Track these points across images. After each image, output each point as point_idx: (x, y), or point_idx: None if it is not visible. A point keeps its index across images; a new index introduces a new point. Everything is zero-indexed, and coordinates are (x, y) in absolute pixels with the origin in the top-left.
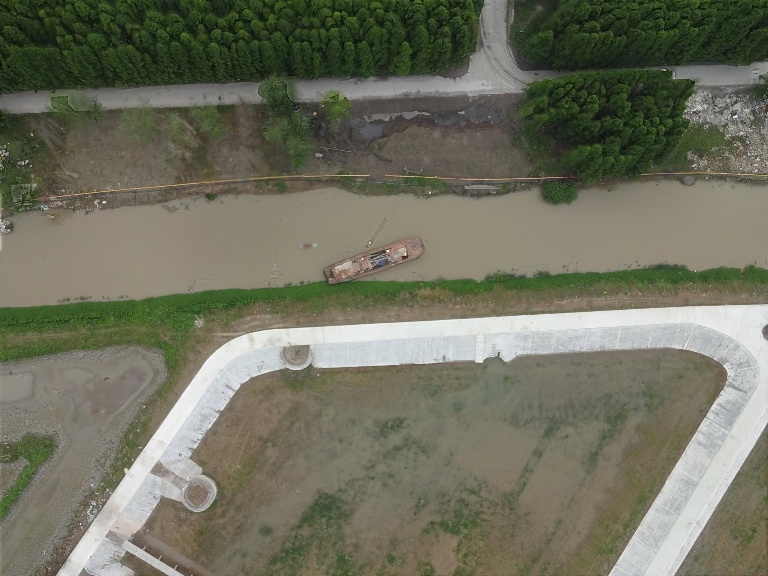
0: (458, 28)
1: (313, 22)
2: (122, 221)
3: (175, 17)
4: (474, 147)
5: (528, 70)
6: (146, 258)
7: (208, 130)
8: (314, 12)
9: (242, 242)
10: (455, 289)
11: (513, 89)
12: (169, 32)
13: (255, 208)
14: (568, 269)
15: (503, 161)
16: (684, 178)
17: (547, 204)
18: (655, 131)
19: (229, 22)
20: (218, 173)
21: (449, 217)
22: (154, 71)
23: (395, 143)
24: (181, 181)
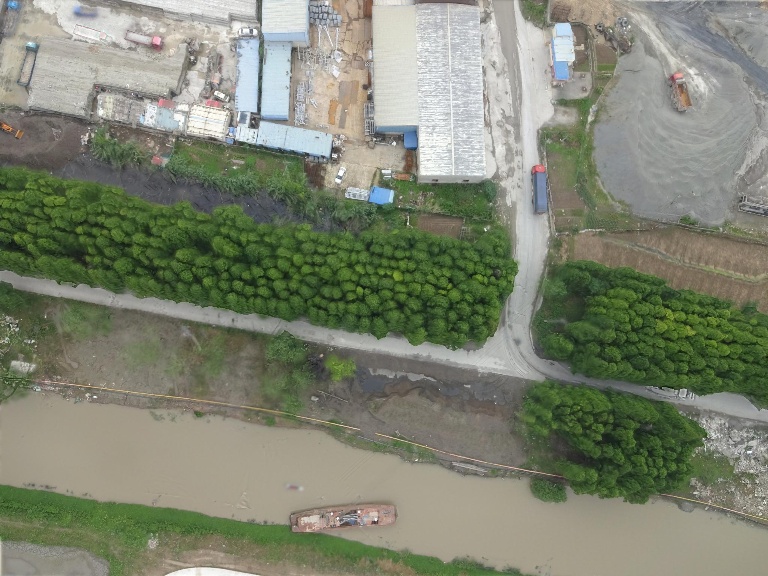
0: (477, 326)
1: (334, 295)
2: (108, 417)
3: (202, 263)
4: (471, 427)
5: (544, 358)
6: (120, 459)
7: (213, 350)
8: (339, 280)
9: (218, 464)
10: (418, 567)
11: (525, 374)
12: (194, 272)
13: (240, 433)
14: (540, 571)
15: (497, 448)
16: (682, 504)
17: (534, 497)
18: (656, 473)
19: (253, 275)
20: (212, 394)
21: (430, 487)
22: (173, 296)
23: (392, 407)
24: (174, 393)
